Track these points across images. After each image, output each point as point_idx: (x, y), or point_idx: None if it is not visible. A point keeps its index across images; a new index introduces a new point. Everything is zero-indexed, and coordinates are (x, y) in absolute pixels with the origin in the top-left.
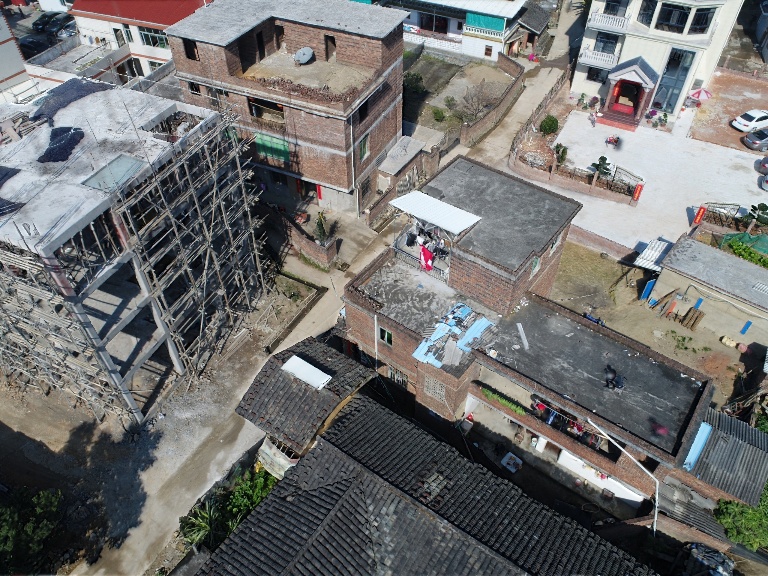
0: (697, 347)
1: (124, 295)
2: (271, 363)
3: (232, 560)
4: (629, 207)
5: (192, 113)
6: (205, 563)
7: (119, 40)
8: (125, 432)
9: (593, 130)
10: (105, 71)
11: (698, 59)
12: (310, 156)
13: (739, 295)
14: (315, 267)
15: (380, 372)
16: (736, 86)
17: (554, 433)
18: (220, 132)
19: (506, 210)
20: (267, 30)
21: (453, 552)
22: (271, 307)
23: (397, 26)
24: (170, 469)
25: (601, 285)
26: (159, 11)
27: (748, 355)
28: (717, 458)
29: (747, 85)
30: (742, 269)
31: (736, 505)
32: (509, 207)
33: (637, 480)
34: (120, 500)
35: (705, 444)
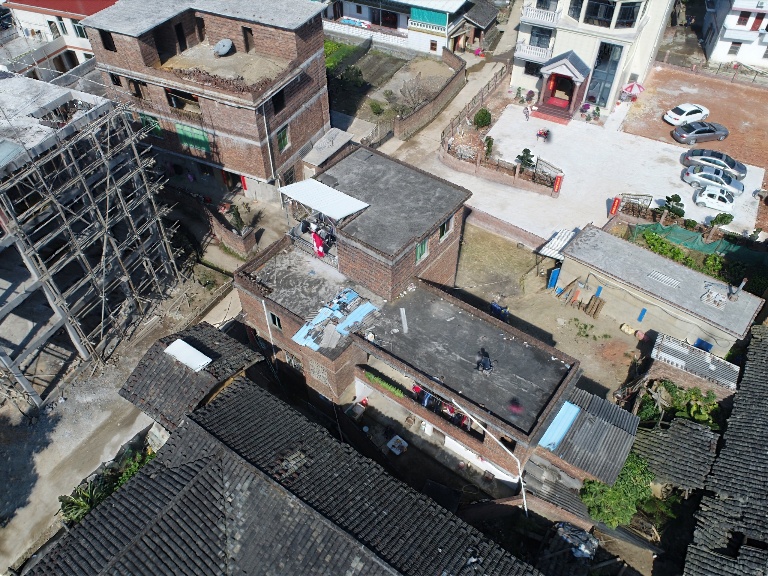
0: (598, 334)
1: (14, 279)
2: (156, 346)
3: (87, 534)
4: (551, 198)
5: (87, 101)
6: (63, 538)
7: (53, 32)
8: (24, 415)
9: (526, 123)
10: (38, 63)
11: (626, 53)
12: (228, 146)
13: (633, 283)
14: (234, 256)
15: (278, 357)
16: (675, 81)
17: (429, 415)
18: (114, 120)
19: (396, 197)
20: (187, 22)
21: (299, 526)
22: (185, 295)
23: (313, 18)
24: (64, 451)
25: (513, 274)
26: (91, 3)
27: (645, 342)
28: (581, 439)
29: (685, 80)
30: (640, 258)
31: (598, 484)
32: (400, 195)
33: (503, 460)
34: (11, 481)
35: (571, 425)
